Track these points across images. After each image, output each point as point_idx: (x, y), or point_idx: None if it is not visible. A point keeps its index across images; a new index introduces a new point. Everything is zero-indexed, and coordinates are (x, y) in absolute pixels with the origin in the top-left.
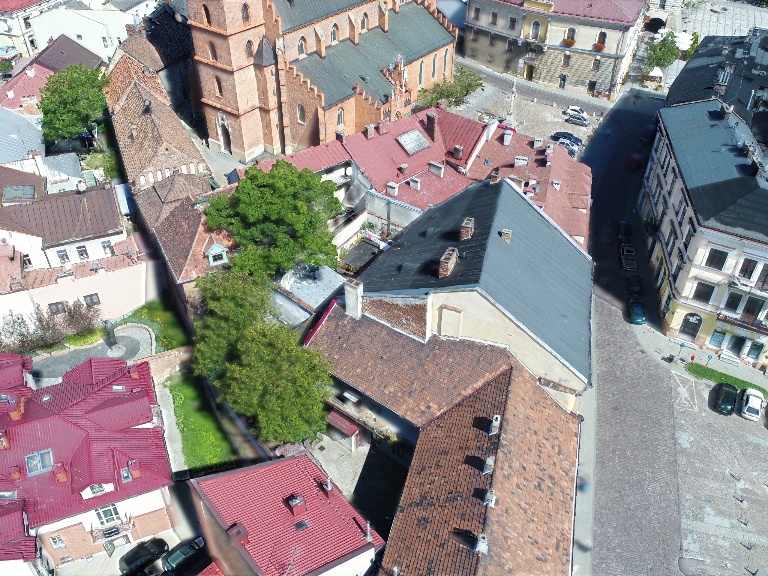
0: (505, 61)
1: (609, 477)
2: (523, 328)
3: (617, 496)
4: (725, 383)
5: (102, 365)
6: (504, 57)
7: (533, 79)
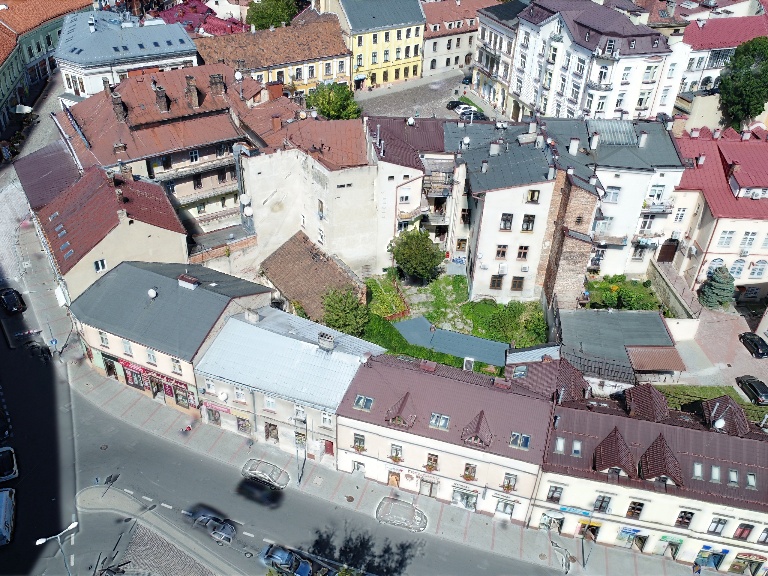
0: None
1: None
2: (340, 1)
3: None
4: None
5: (235, 20)
6: None
7: None
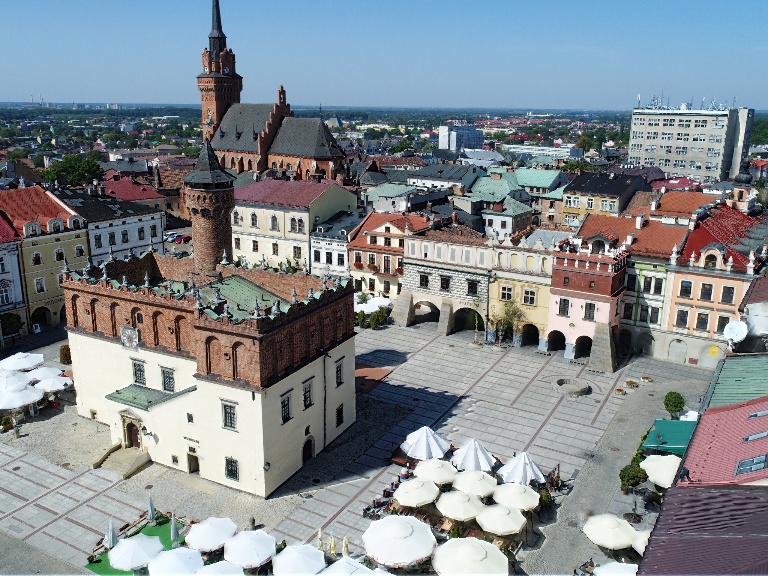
0: None
1: None
2: None
3: None
4: None
5: None
6: None
7: None
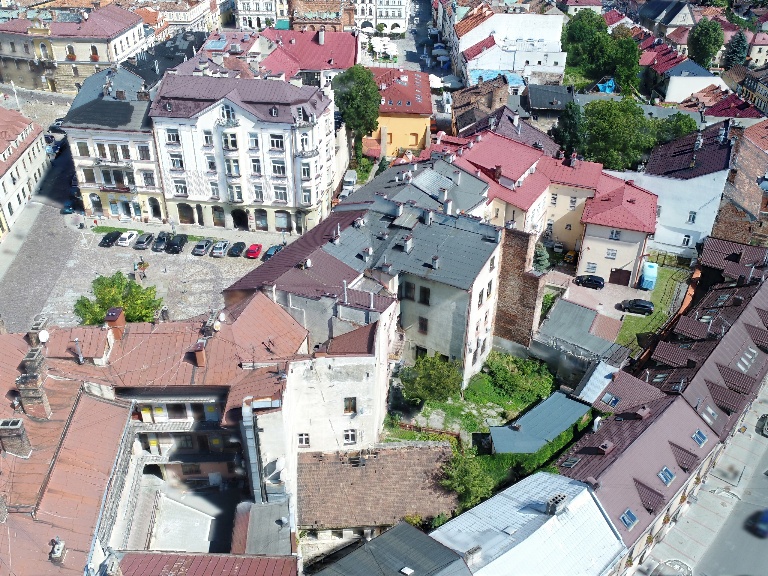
0: (32, 80)
1: (5, 289)
2: None
3: (7, 297)
4: (114, 231)
5: None
6: (30, 77)
7: (57, 90)
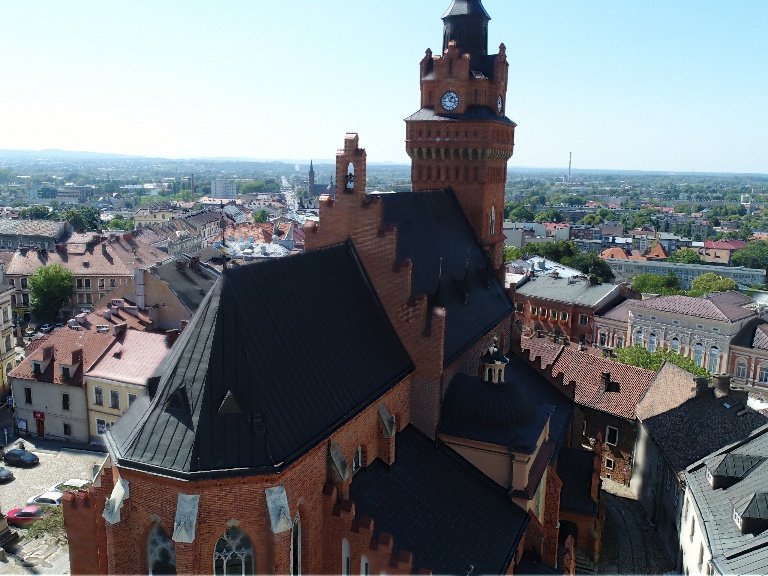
0: None
1: None
2: None
3: None
4: None
5: None
6: None
7: None
